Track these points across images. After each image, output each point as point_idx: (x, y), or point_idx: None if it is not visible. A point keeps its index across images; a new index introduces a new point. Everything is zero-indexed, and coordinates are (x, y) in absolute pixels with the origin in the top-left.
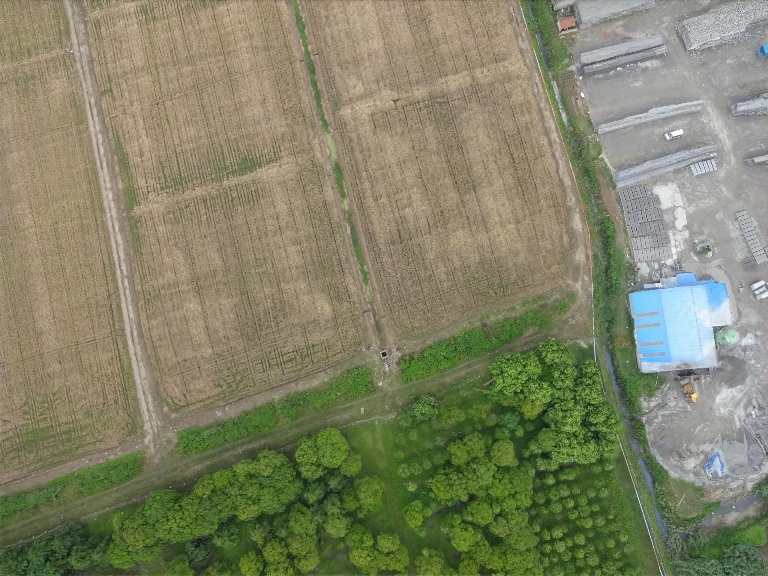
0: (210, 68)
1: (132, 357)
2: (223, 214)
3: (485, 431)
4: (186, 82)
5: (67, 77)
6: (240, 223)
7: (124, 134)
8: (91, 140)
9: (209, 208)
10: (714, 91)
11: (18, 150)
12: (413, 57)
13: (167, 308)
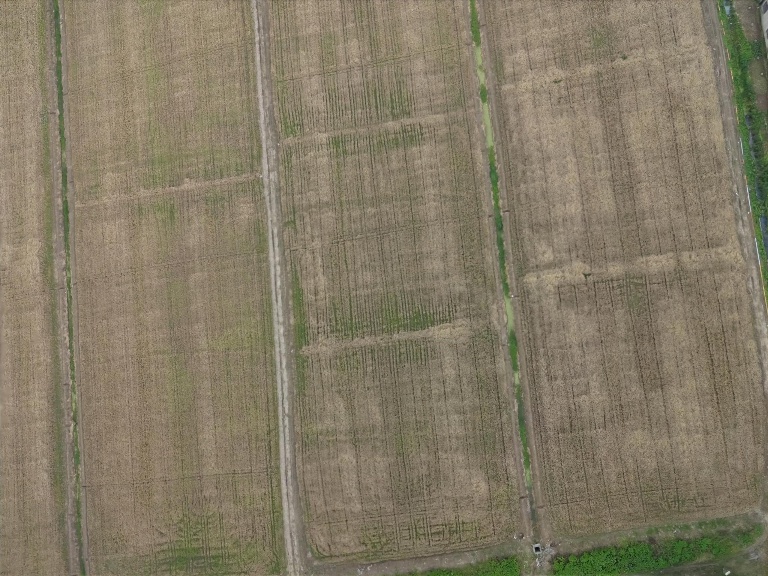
0: (395, 212)
1: (284, 497)
2: (389, 368)
3: None
4: (369, 224)
5: (254, 203)
6: (405, 381)
7: (302, 269)
8: (269, 270)
9: (376, 360)
10: None
11: (201, 271)
12: (613, 229)
13: (323, 455)
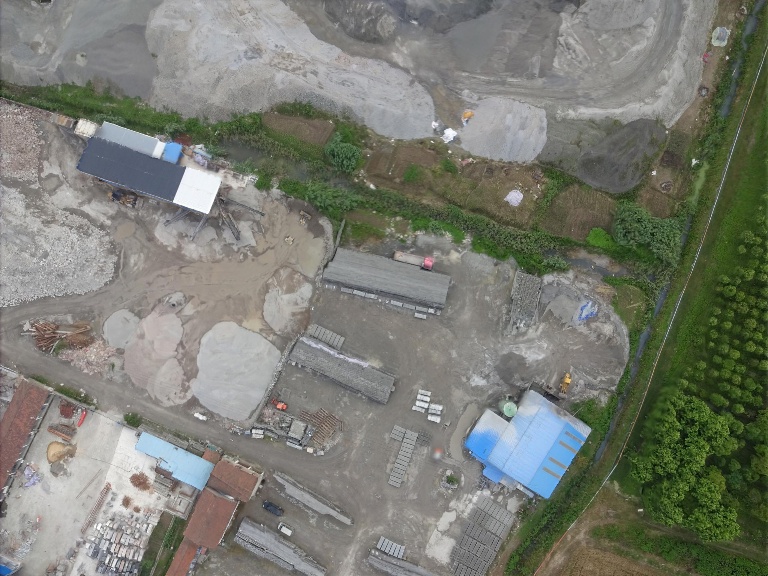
0: None
1: None
2: None
3: (755, 483)
4: None
5: None
6: None
7: None
8: None
9: None
10: None
11: None
12: None
13: None
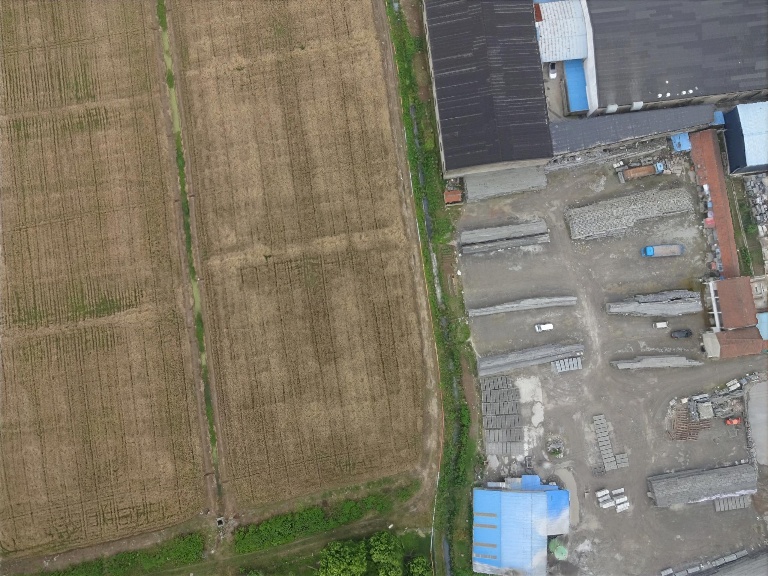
0: (79, 197)
1: None
2: (75, 356)
3: None
4: (52, 210)
5: None
6: (91, 368)
7: None
8: None
9: (61, 348)
10: (592, 285)
11: None
12: (292, 212)
13: (6, 448)
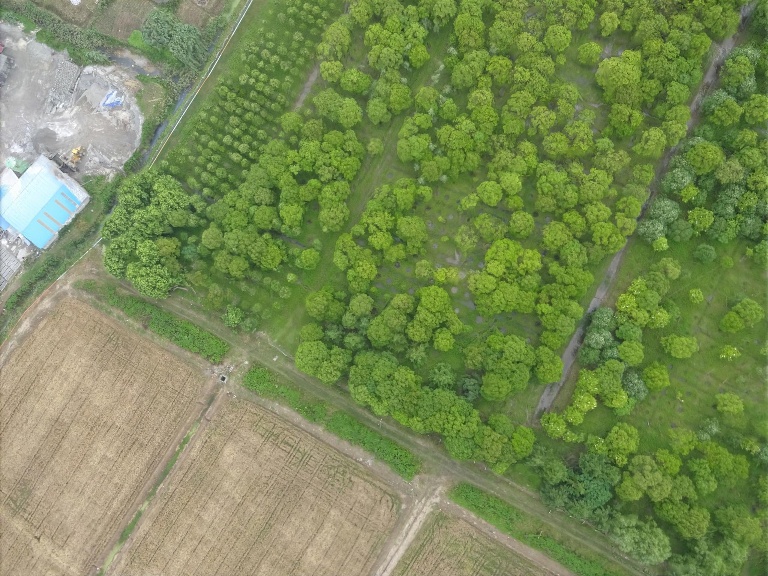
0: None
1: (390, 571)
2: None
3: None
4: None
5: None
6: None
7: None
8: None
9: None
10: None
11: None
12: None
13: None
